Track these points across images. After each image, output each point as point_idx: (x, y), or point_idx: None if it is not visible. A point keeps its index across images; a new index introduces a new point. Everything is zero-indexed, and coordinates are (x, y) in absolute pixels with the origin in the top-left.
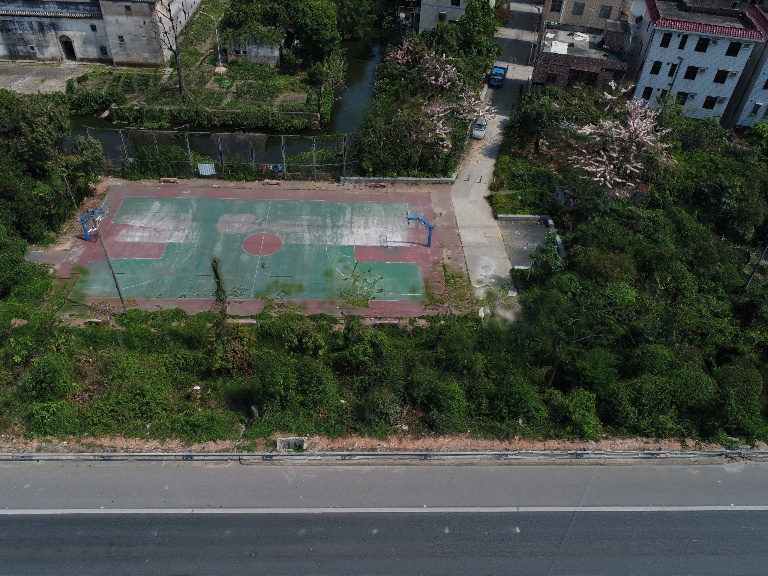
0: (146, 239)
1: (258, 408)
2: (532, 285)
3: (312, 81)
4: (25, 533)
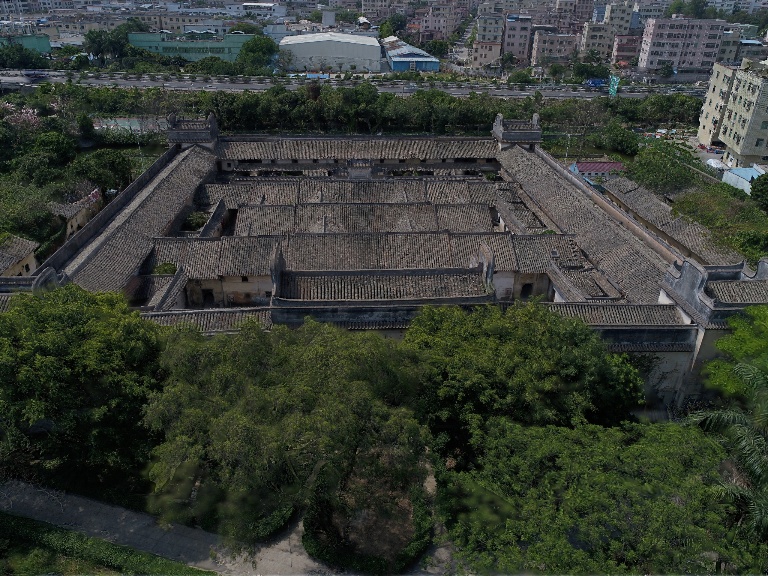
0: None
1: None
2: None
3: None
4: None
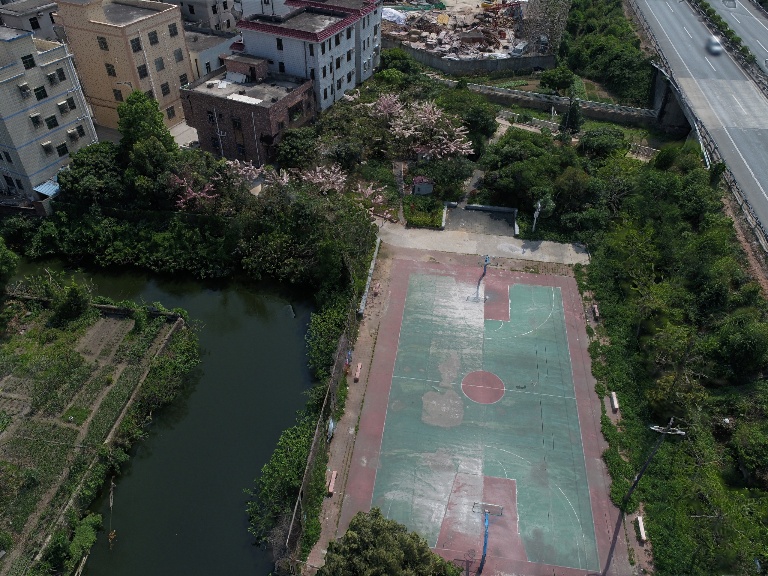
0: (477, 499)
1: (748, 373)
2: (539, 231)
3: (74, 312)
4: None
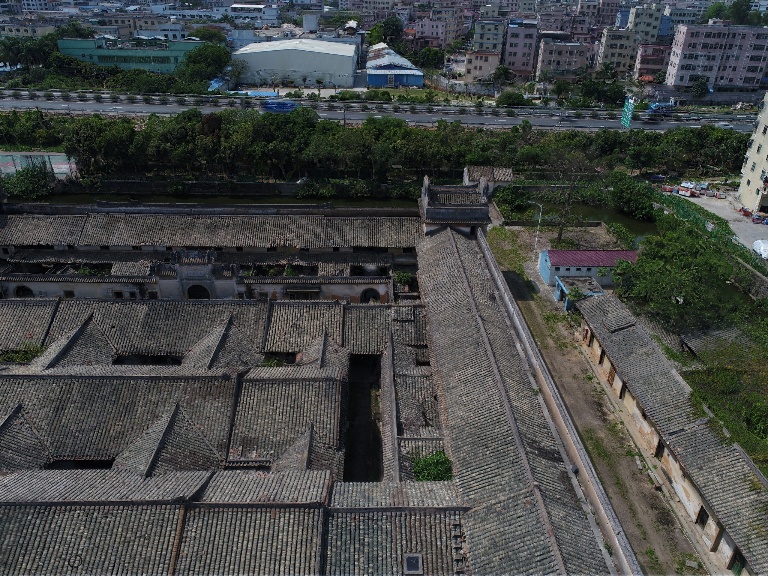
0: (61, 165)
1: None
2: None
3: None
4: (101, 109)
